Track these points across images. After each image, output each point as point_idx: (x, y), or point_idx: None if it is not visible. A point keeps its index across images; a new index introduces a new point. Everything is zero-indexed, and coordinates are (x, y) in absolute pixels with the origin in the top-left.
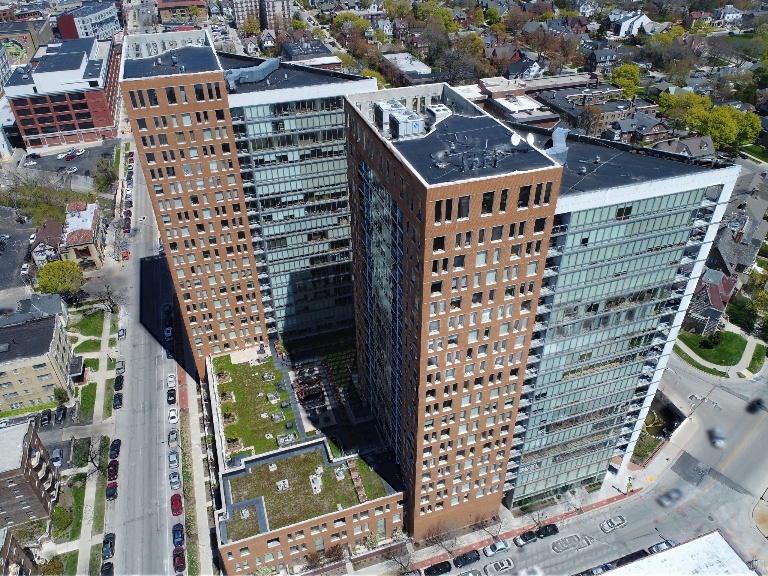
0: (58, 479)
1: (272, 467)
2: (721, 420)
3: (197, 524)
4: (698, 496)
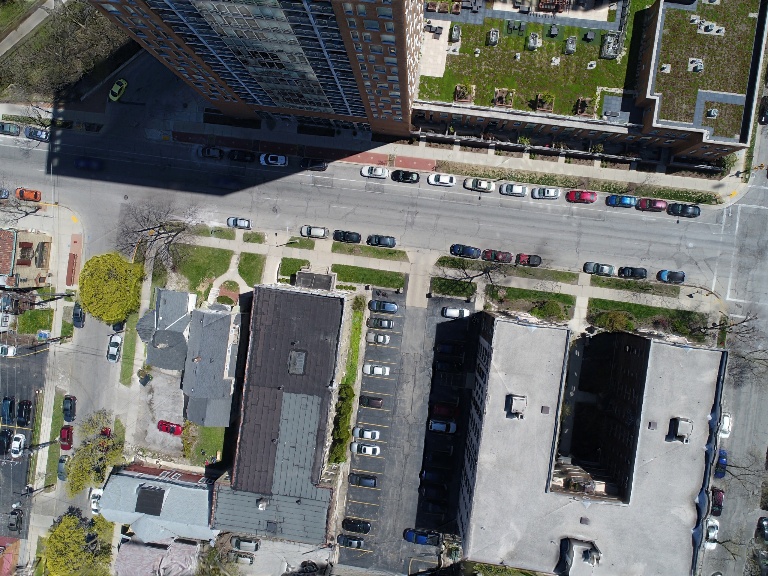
0: None
1: (667, 69)
2: None
3: (617, 181)
4: None
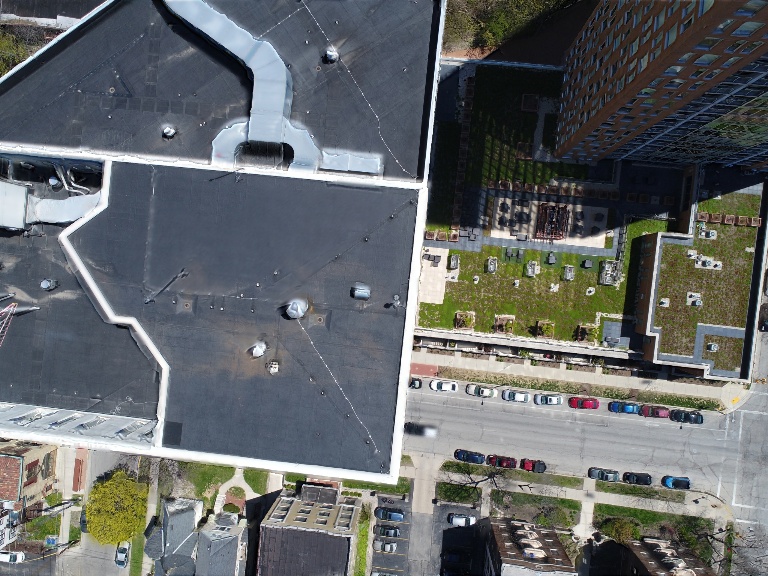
0: (496, 520)
1: (665, 304)
2: None
3: (619, 387)
4: None
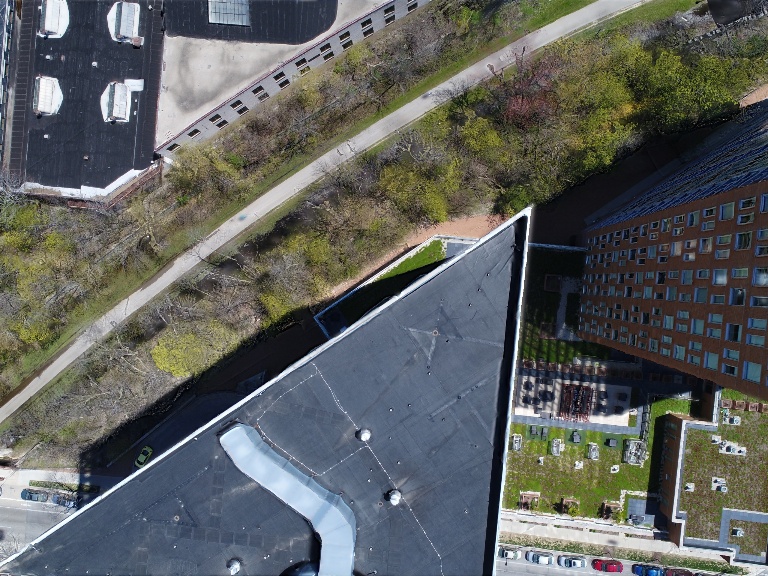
0: None
1: (691, 489)
2: None
3: (643, 550)
4: None
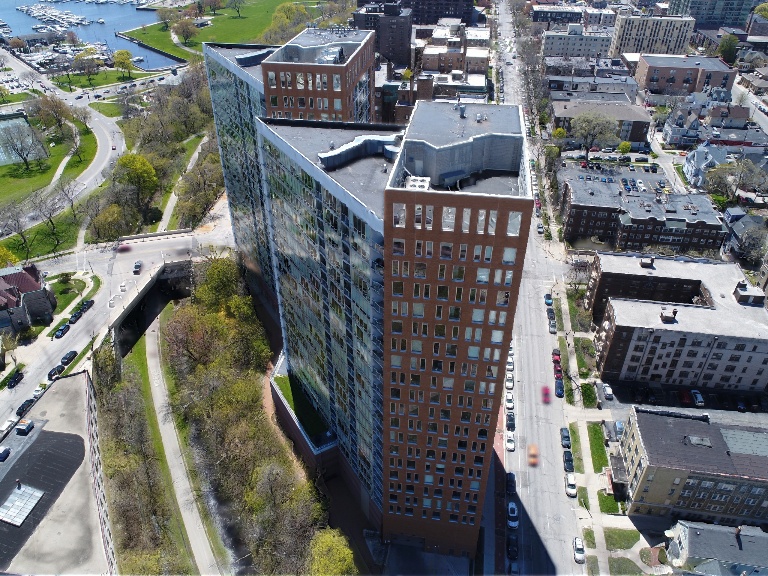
0: None
1: None
2: (146, 261)
3: None
4: (218, 244)
